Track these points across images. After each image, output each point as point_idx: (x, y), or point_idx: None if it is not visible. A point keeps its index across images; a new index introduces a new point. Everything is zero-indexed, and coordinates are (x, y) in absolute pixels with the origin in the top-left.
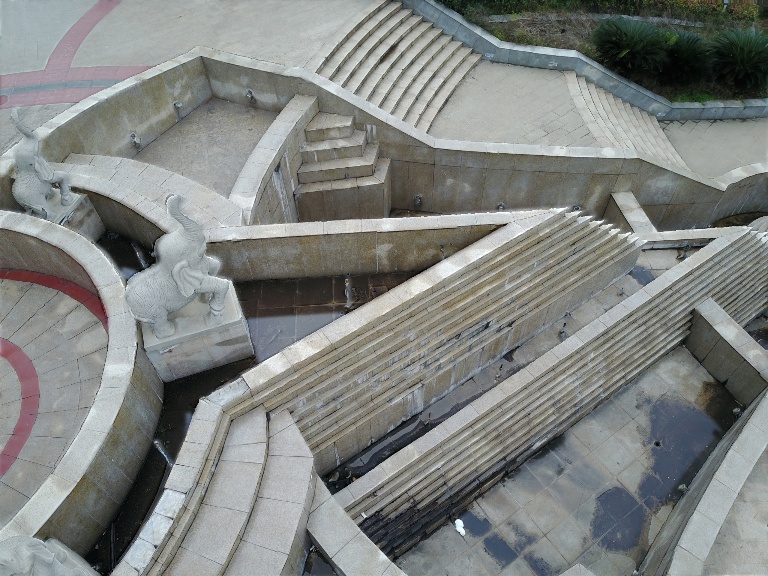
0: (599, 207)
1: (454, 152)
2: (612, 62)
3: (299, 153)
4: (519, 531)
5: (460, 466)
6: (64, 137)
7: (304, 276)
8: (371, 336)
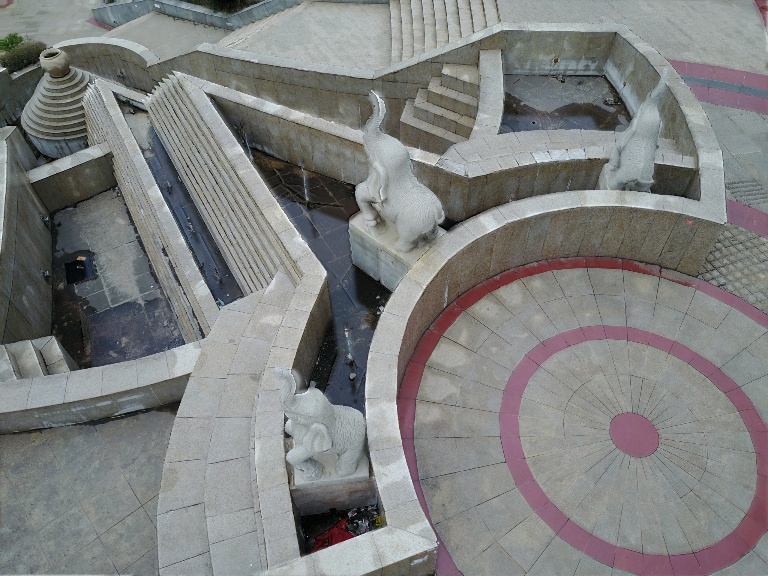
0: (40, 202)
1: (1, 269)
2: None
3: None
4: None
5: None
6: None
7: None
8: None
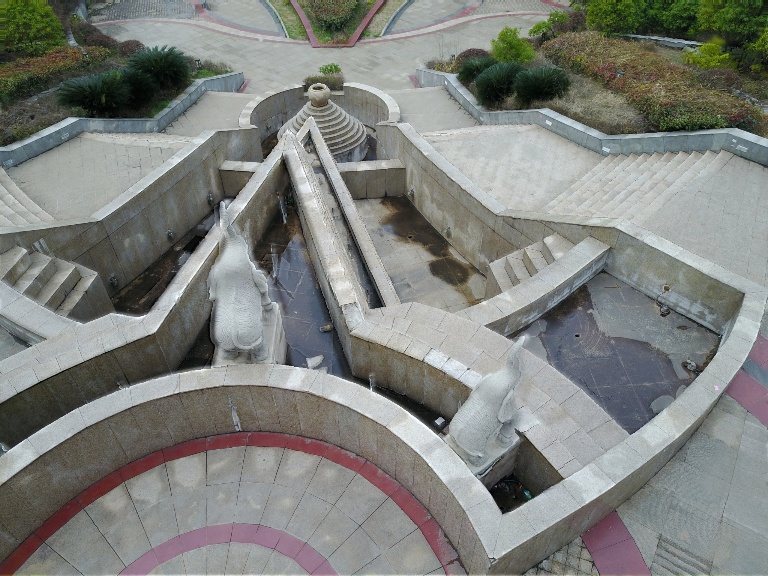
0: (218, 185)
1: (116, 212)
2: (98, 112)
3: None
4: None
5: None
6: None
7: None
8: None
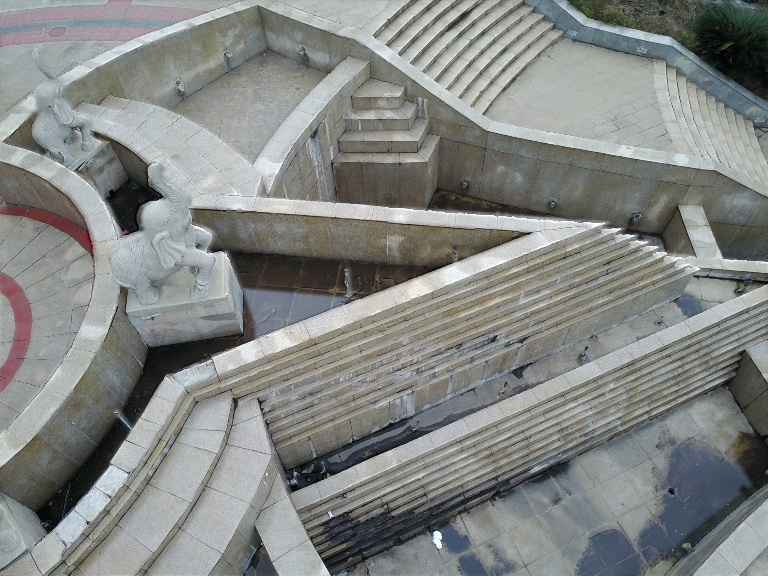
0: (662, 218)
1: (508, 138)
2: (711, 54)
3: (342, 120)
4: (499, 556)
5: (444, 480)
6: (103, 78)
7: (311, 256)
8: (357, 335)
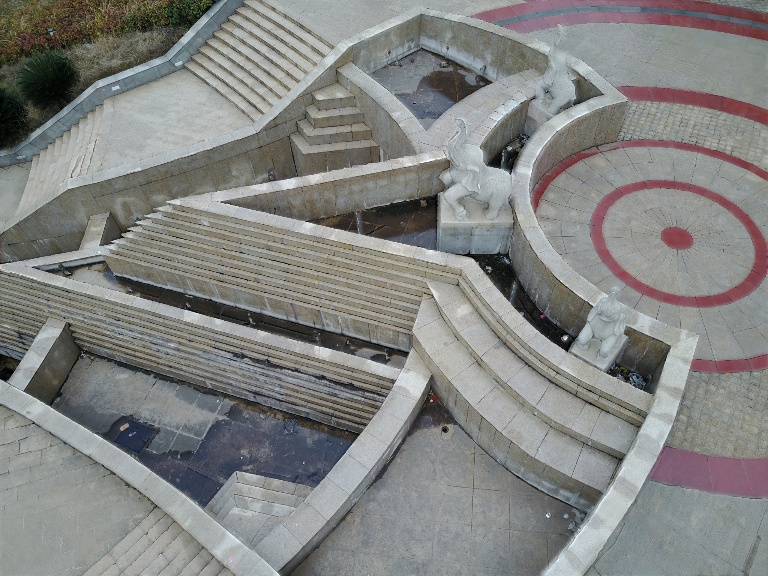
0: None
1: None
2: None
3: None
4: None
5: None
6: None
7: None
8: None
